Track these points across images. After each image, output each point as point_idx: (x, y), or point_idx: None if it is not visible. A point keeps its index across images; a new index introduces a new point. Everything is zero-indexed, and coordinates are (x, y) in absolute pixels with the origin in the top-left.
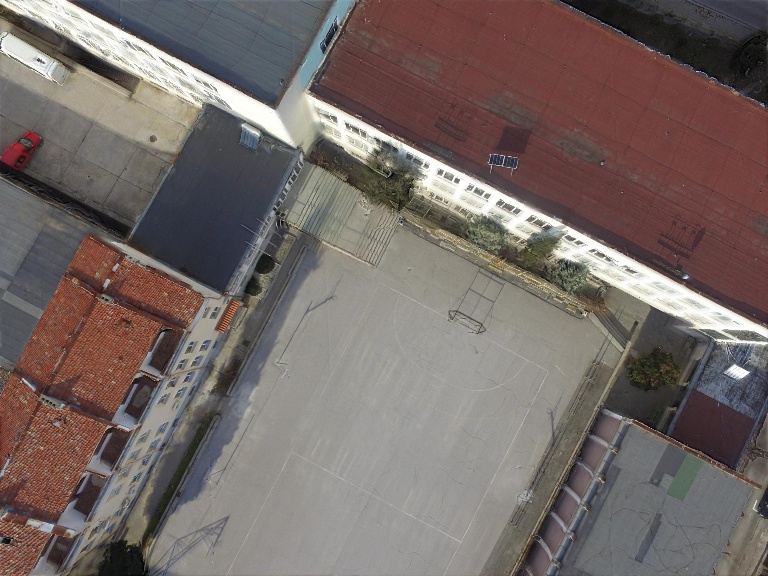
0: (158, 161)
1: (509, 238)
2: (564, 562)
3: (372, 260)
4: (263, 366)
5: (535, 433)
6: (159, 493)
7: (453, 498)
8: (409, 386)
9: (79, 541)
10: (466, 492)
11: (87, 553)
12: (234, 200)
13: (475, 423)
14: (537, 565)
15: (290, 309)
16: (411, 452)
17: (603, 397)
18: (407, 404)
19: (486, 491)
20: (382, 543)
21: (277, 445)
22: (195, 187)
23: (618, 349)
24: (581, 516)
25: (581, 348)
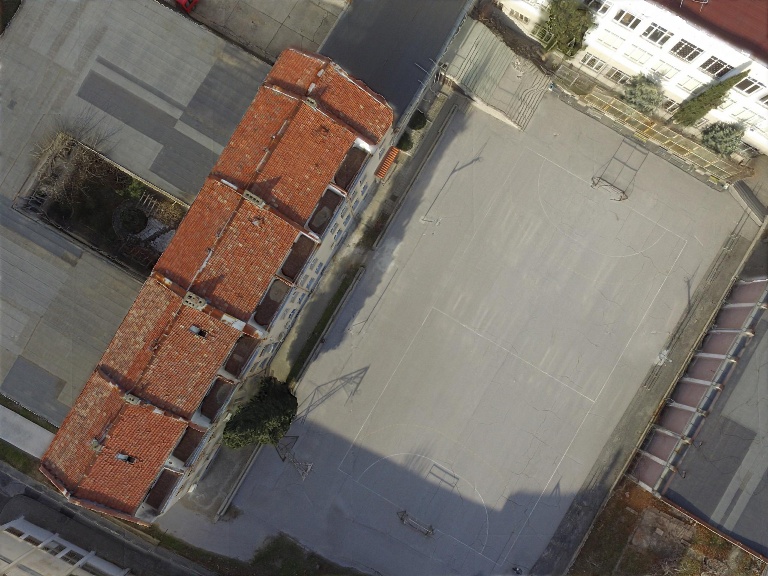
0: (320, 11)
1: (662, 102)
2: (711, 410)
3: (520, 123)
4: (408, 222)
5: (671, 300)
6: (303, 340)
7: (589, 359)
8: (550, 249)
9: (256, 352)
10: (602, 354)
11: (251, 376)
12: (409, 39)
13: (613, 288)
14: (672, 424)
15: (437, 168)
16: (550, 313)
17: (740, 268)
18: (548, 266)
19: (621, 354)
20: (518, 399)
21: (419, 300)
22: (371, 25)
23: (756, 223)
24: (727, 369)
25: (720, 220)
